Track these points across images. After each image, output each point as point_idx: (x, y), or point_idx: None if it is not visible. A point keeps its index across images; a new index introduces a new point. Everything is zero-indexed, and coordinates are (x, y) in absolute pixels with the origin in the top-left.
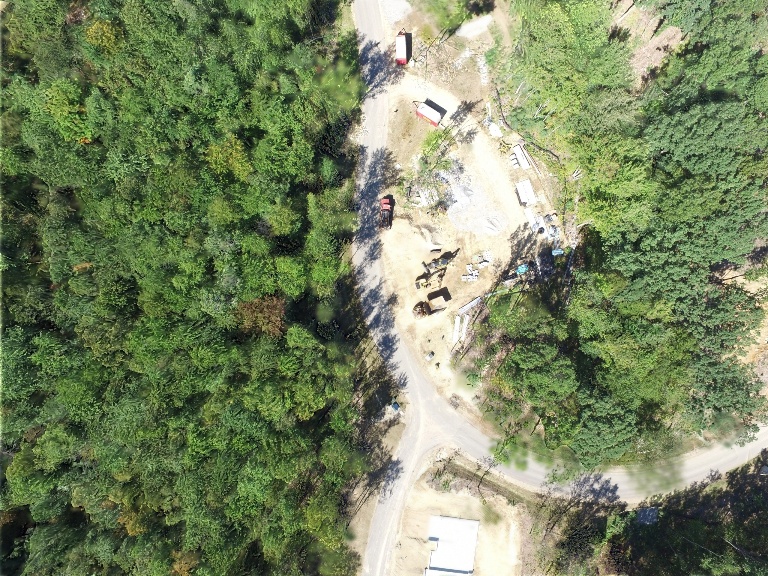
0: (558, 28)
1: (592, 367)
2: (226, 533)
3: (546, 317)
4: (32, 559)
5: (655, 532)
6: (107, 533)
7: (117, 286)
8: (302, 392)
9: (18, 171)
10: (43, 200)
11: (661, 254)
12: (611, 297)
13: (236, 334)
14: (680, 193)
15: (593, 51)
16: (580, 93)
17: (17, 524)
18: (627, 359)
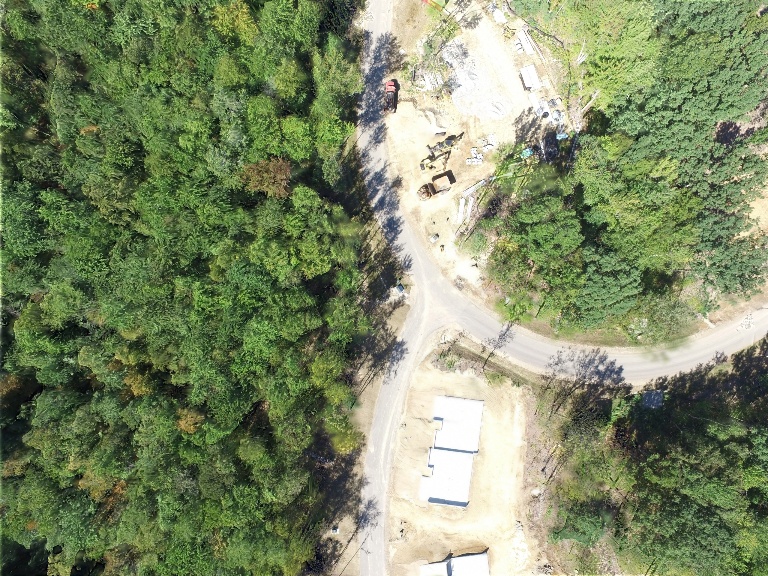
0: None
1: (597, 231)
2: (232, 387)
3: None
4: (39, 415)
5: (660, 415)
6: (113, 394)
7: (124, 146)
8: (307, 248)
9: (26, 35)
10: (50, 76)
11: (666, 112)
12: (616, 159)
13: (242, 197)
14: (685, 49)
15: None
16: None
17: (24, 394)
18: (632, 218)
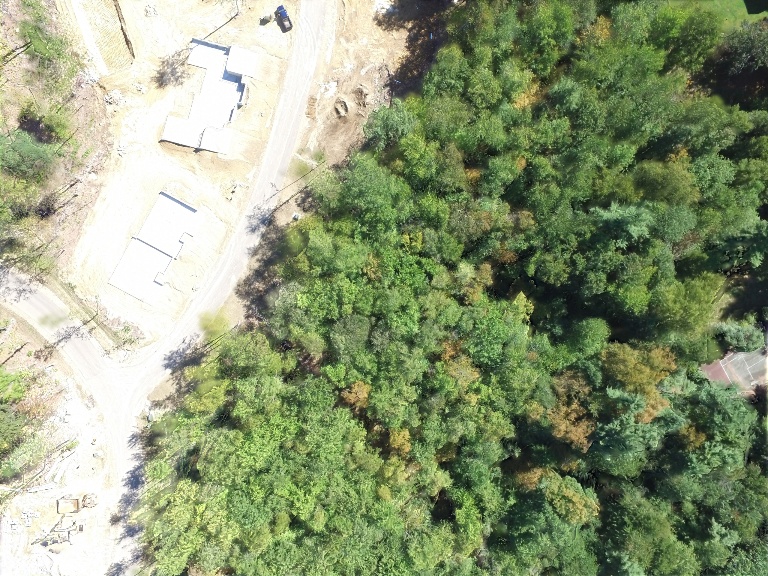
0: None
1: None
2: None
3: None
4: None
5: None
6: None
7: None
8: None
9: None
10: None
11: None
12: None
13: None
14: None
15: None
16: None
17: (520, 461)
18: None
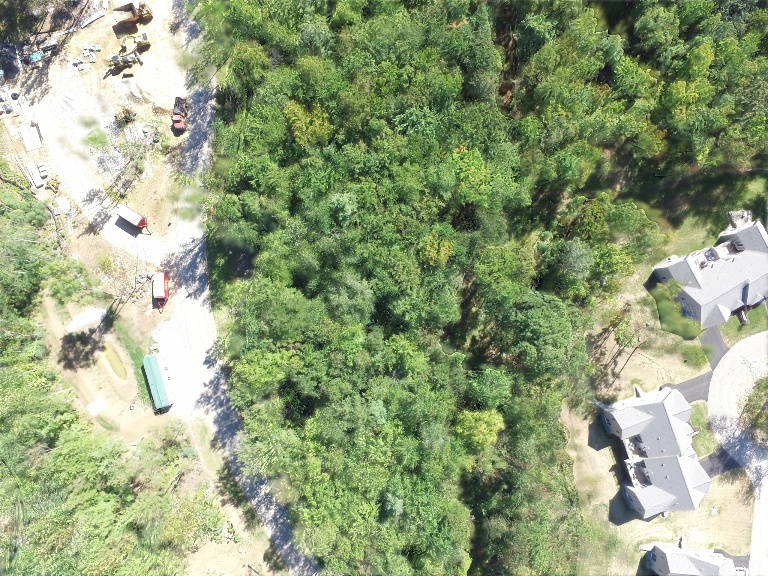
0: None
1: None
2: None
3: (12, 6)
4: None
5: None
6: None
7: None
8: None
9: None
10: None
11: None
12: None
13: None
14: None
15: None
16: None
17: None
18: None
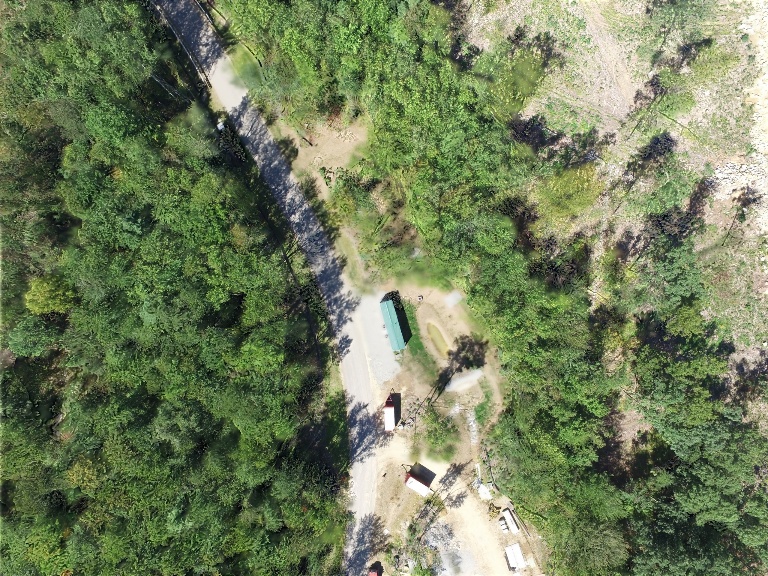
0: (547, 458)
1: None
2: None
3: None
4: None
5: None
6: None
7: None
8: None
9: None
10: None
11: None
12: None
13: None
14: None
15: (582, 469)
16: (569, 519)
17: None
18: None
